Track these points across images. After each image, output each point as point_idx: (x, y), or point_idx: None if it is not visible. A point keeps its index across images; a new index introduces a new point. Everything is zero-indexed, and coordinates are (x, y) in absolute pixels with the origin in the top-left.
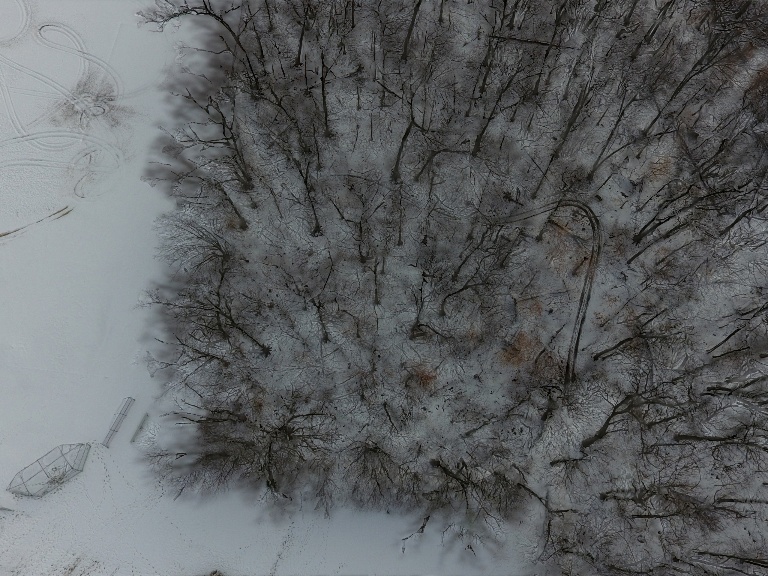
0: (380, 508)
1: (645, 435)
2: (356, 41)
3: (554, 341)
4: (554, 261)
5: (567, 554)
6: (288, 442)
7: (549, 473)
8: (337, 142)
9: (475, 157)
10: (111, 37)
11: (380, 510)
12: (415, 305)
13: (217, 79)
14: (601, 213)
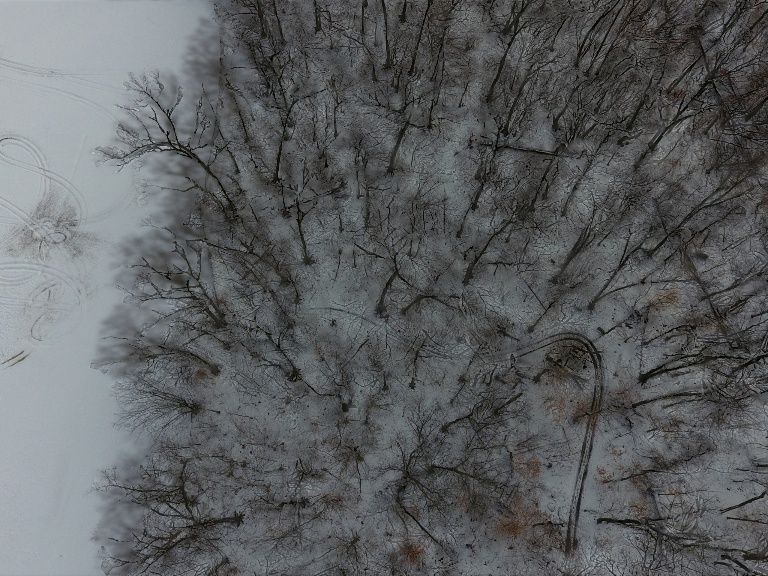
0: None
1: None
2: (339, 153)
3: (554, 501)
4: (553, 411)
5: None
6: None
7: None
8: (317, 271)
9: (467, 285)
10: (75, 152)
11: None
12: (402, 461)
13: (188, 200)
14: (603, 348)
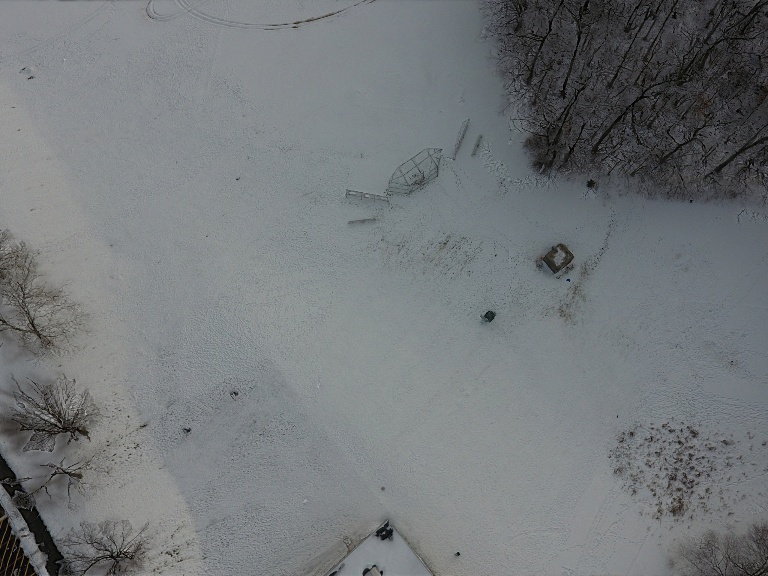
0: (684, 198)
1: None
2: None
3: None
4: None
5: None
6: (596, 157)
7: None
8: None
9: None
10: None
11: (684, 200)
12: (677, 61)
13: None
14: None
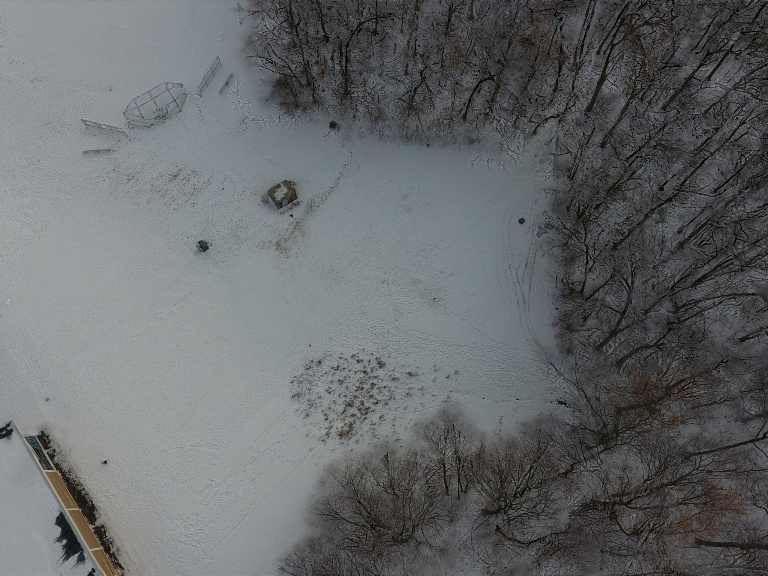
0: (422, 142)
1: (638, 105)
2: None
3: (564, 40)
4: None
5: (573, 179)
6: (346, 100)
7: None
8: None
9: None
10: None
11: (422, 144)
12: None
13: None
14: None
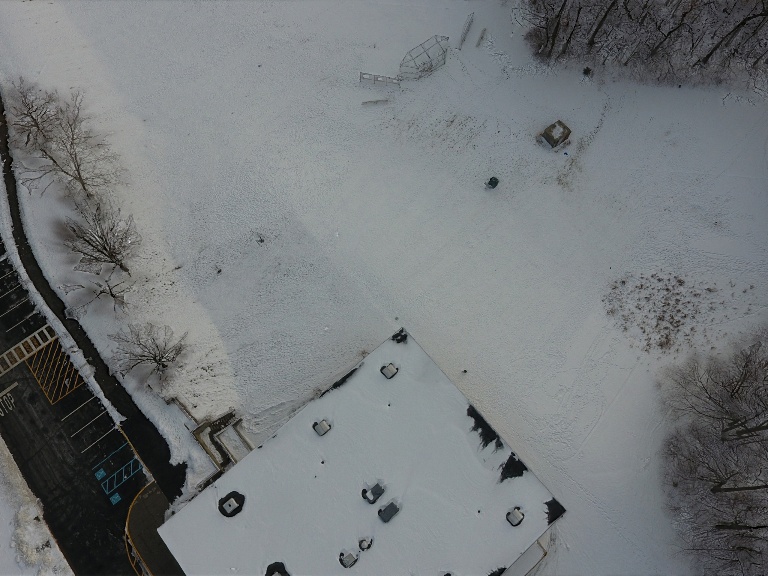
0: (673, 84)
1: None
2: None
3: None
4: None
5: None
6: (592, 49)
7: None
8: None
9: None
10: None
11: (673, 86)
12: None
13: None
14: None
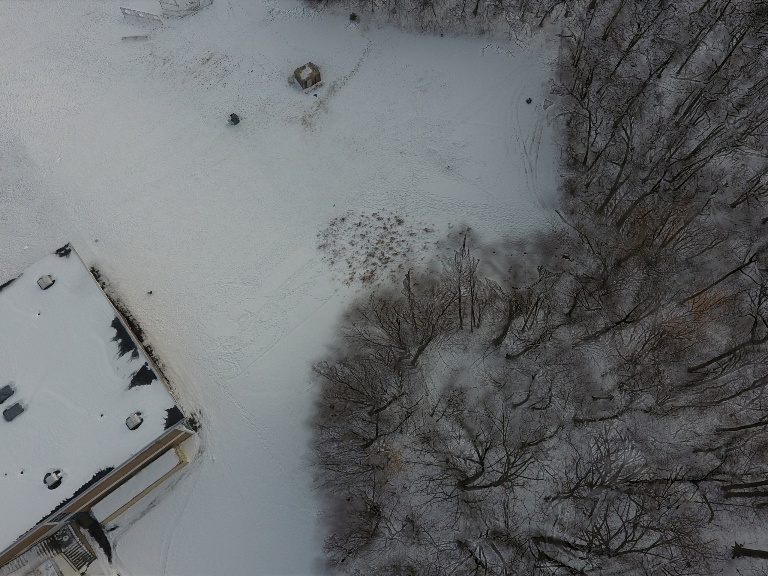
0: (436, 32)
1: (638, 3)
2: None
3: None
4: None
5: None
6: None
7: (564, 20)
8: None
9: None
10: None
11: (436, 34)
12: None
13: None
14: None
